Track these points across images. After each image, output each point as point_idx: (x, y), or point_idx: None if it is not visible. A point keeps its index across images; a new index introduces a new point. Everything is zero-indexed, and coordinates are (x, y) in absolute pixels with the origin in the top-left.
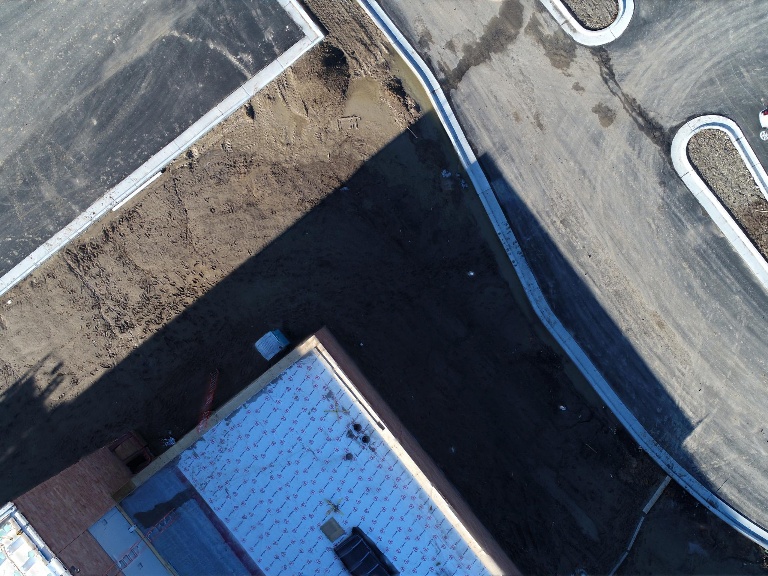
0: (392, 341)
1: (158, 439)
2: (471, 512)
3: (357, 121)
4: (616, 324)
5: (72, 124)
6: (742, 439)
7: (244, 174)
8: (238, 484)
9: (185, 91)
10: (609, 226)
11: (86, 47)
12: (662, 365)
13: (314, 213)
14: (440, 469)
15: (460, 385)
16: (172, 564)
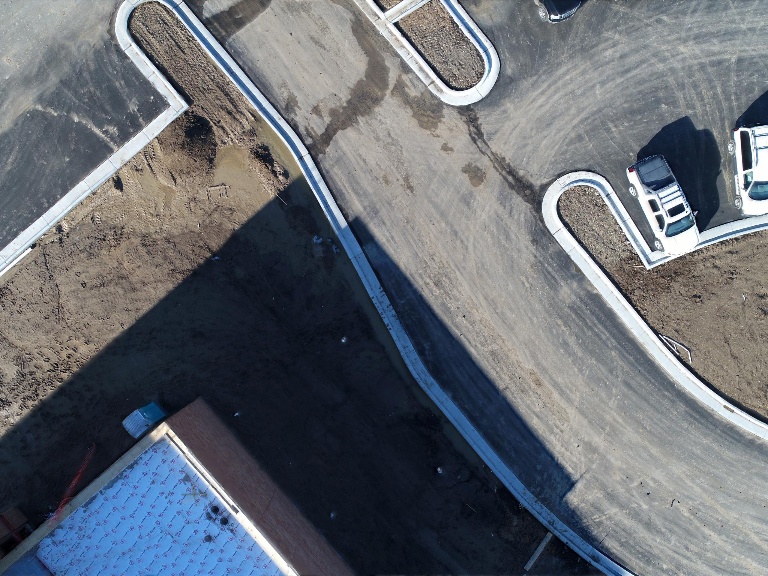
0: (268, 409)
1: (38, 515)
2: None
3: (226, 190)
4: (493, 383)
5: None
6: (622, 493)
7: (114, 247)
8: (98, 570)
9: (52, 166)
10: (483, 286)
11: None
12: (540, 422)
13: (186, 284)
14: (321, 534)
15: (338, 450)
16: None
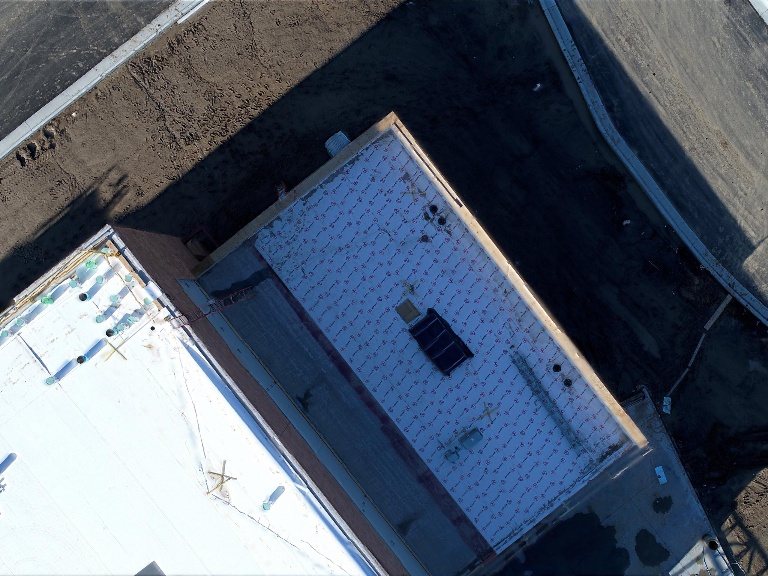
0: (457, 156)
1: None
2: None
3: None
4: (679, 143)
5: None
6: None
7: None
8: (314, 264)
9: None
10: (674, 44)
11: None
12: (725, 184)
13: (380, 27)
14: None
15: (524, 201)
16: (248, 343)
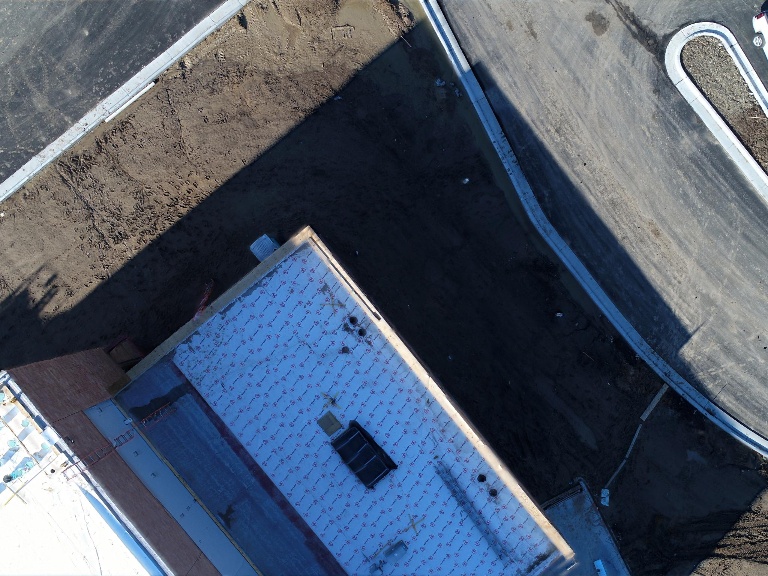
0: (388, 250)
1: None
2: (469, 420)
3: (351, 30)
4: (612, 232)
5: (64, 35)
6: (739, 346)
7: (237, 84)
8: (234, 378)
9: (177, 1)
10: (604, 134)
11: None
12: (658, 273)
13: (308, 122)
14: (437, 378)
15: (456, 294)
16: (168, 459)
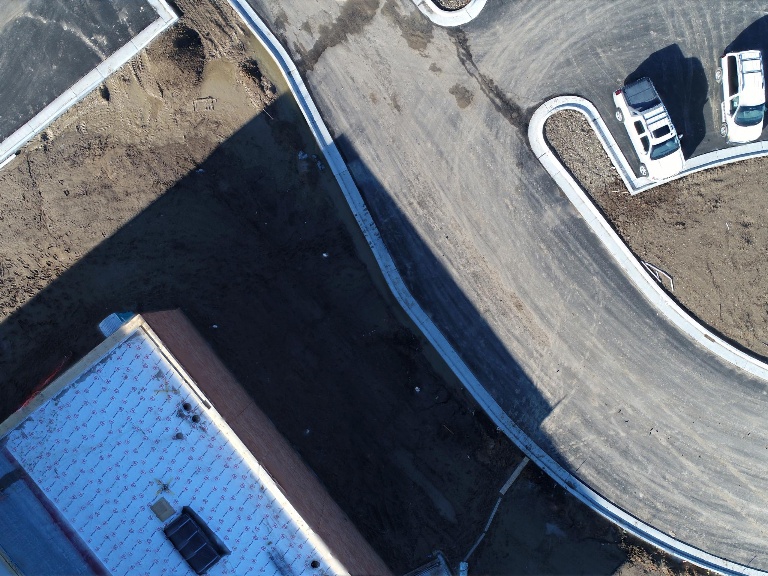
0: (248, 323)
1: None
2: (327, 494)
3: (213, 103)
4: (474, 305)
5: None
6: (600, 420)
7: (99, 156)
8: (67, 464)
9: (39, 73)
10: (467, 207)
11: None
12: (520, 346)
13: (169, 195)
14: (296, 451)
15: (317, 367)
16: (1, 545)
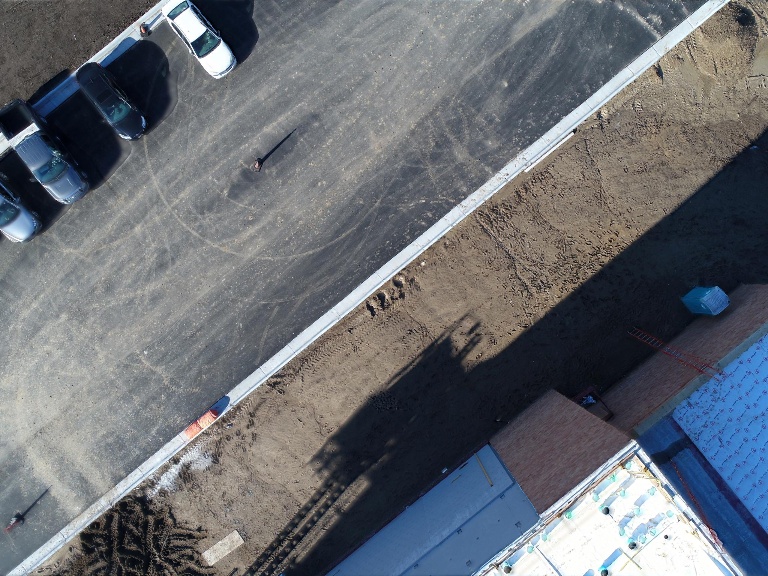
0: None
1: None
2: None
3: (765, 80)
4: None
5: (483, 86)
6: None
7: (655, 134)
8: (731, 433)
9: (595, 52)
10: None
11: (496, 10)
12: None
13: (726, 172)
14: None
15: None
16: None
